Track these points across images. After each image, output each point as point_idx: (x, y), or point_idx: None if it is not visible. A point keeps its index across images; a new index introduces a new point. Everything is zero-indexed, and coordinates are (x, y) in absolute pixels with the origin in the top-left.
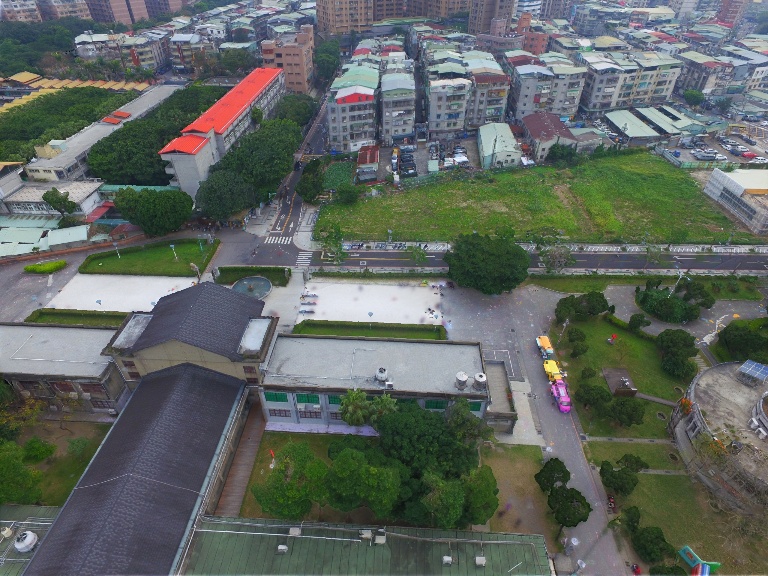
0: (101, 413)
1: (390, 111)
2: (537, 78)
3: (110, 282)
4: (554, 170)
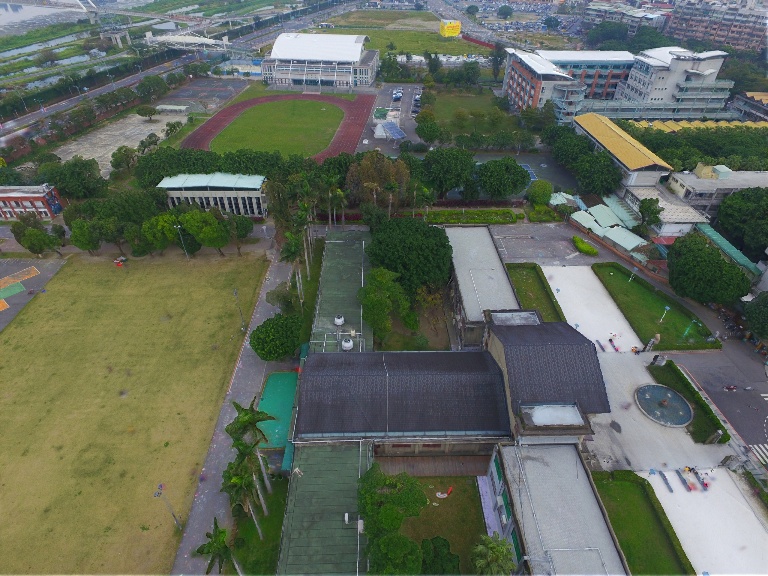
0: (458, 344)
1: None
2: None
3: (595, 289)
4: None
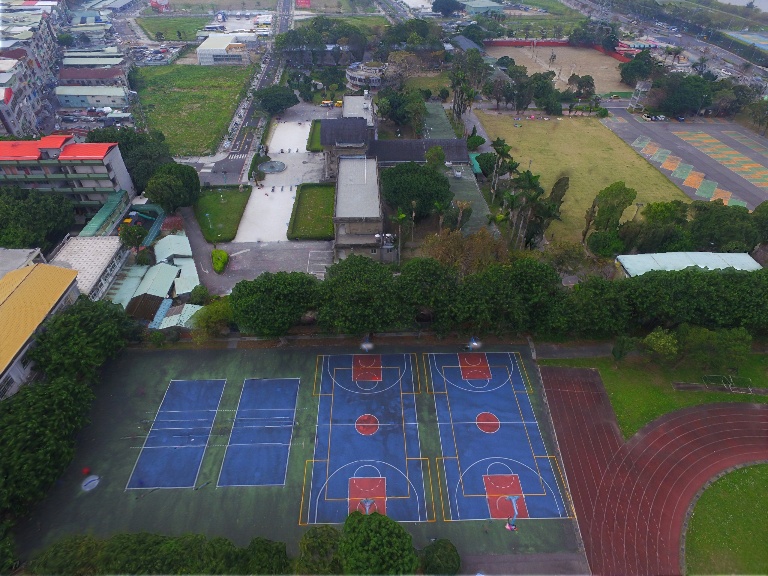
0: None
1: (20, 101)
2: (26, 45)
3: (250, 223)
4: (147, 90)
